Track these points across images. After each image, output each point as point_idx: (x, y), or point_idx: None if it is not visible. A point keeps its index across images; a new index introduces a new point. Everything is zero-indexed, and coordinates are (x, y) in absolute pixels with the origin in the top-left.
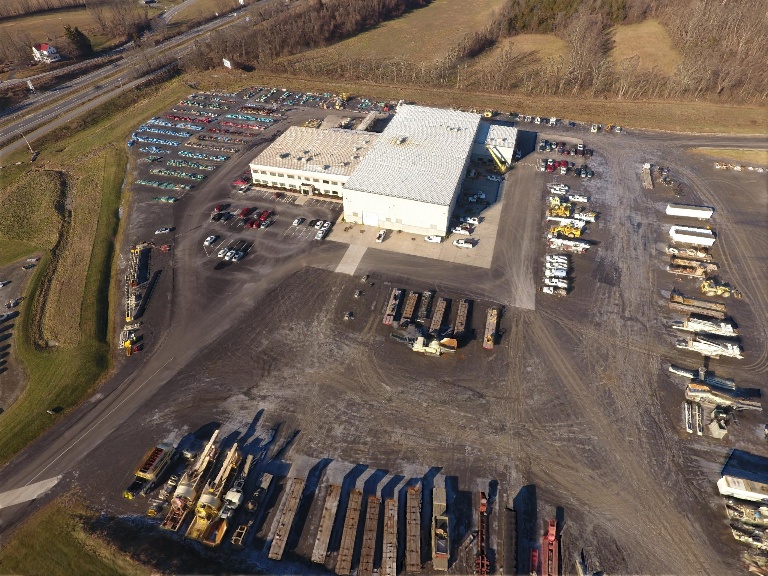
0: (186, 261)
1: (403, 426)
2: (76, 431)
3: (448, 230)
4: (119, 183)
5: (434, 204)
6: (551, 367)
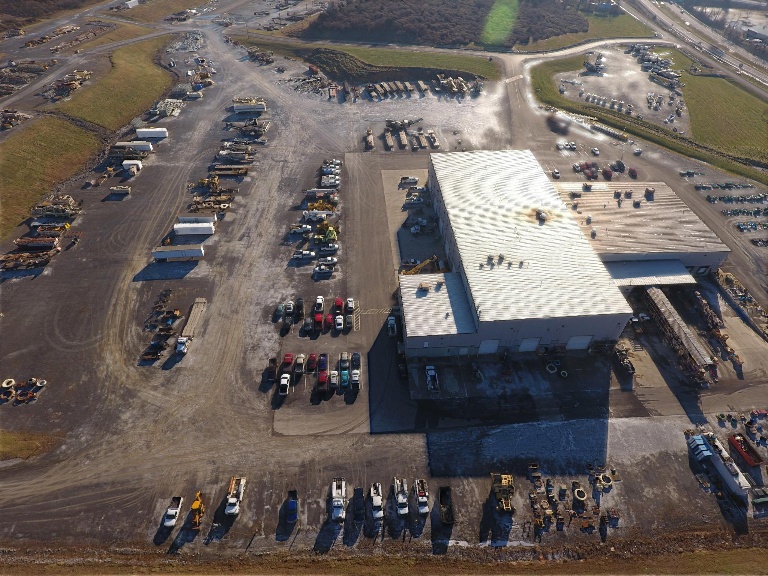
0: (588, 140)
1: (398, 108)
2: (521, 89)
3: (428, 190)
4: (764, 182)
5: (443, 153)
6: (333, 133)
